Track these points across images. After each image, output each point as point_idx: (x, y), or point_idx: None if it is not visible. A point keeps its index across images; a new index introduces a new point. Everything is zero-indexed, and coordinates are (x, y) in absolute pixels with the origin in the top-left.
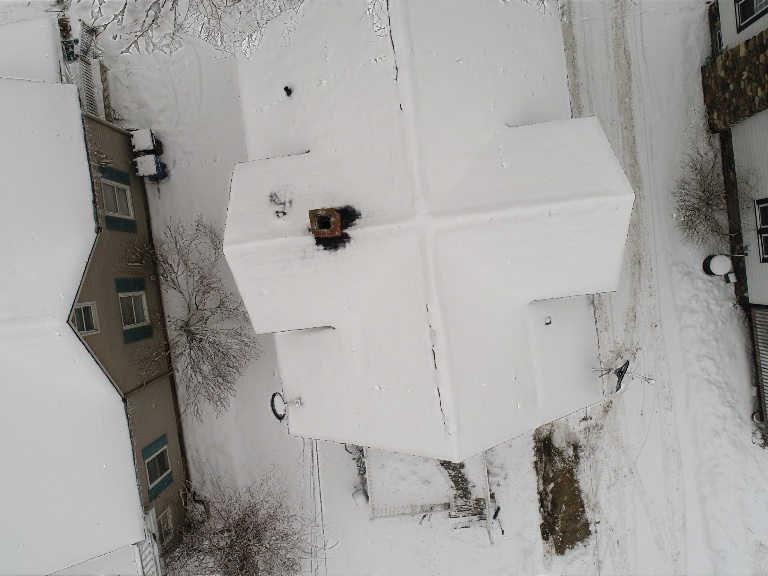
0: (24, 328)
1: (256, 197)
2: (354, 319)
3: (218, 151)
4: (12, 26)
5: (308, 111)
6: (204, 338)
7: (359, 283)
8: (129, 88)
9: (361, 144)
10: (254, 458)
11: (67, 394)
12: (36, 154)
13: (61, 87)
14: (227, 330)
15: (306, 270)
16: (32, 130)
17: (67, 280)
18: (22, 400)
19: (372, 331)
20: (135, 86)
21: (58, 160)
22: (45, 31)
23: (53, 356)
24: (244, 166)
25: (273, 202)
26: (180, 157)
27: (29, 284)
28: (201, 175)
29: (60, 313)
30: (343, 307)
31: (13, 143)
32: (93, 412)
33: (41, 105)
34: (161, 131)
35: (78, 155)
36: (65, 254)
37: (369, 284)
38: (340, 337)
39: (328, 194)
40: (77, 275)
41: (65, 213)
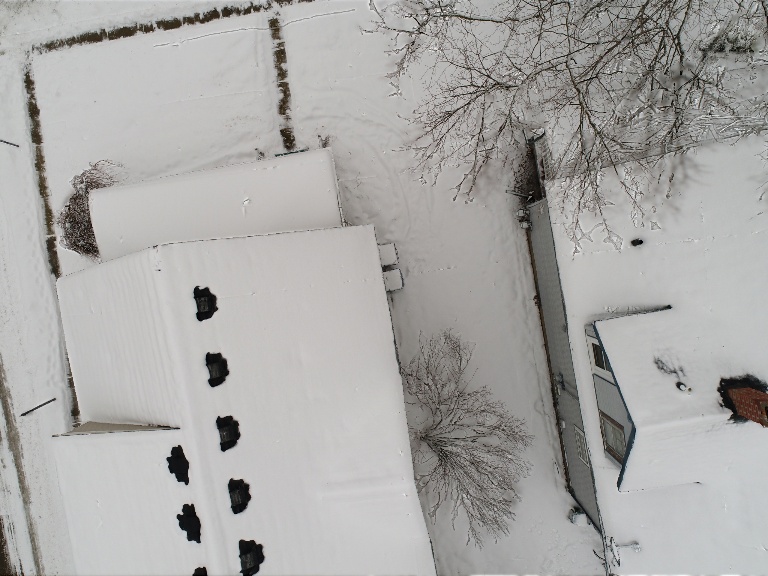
0: (371, 491)
1: (642, 364)
2: (730, 477)
3: (452, 258)
4: (291, 161)
5: (667, 265)
6: (454, 451)
7: (751, 448)
8: (360, 198)
9: (752, 309)
10: (495, 564)
11: (390, 544)
12: (351, 303)
13: (363, 229)
14: (490, 447)
15: (705, 440)
16: (346, 279)
17: (398, 434)
18: (357, 558)
19: (757, 492)
20: (367, 196)
21: (367, 305)
22: (325, 165)
23: (387, 512)
24: (610, 326)
25: (662, 370)
26: (413, 265)
27: (357, 438)
28: (435, 283)
29: (407, 474)
30: (723, 468)
31: (333, 295)
32: (410, 558)
33: (351, 251)
34: (394, 240)
35: (381, 297)
36: (383, 402)
37: (762, 449)
38: (706, 492)
39: (719, 360)
40: (404, 427)
41: (376, 358)
